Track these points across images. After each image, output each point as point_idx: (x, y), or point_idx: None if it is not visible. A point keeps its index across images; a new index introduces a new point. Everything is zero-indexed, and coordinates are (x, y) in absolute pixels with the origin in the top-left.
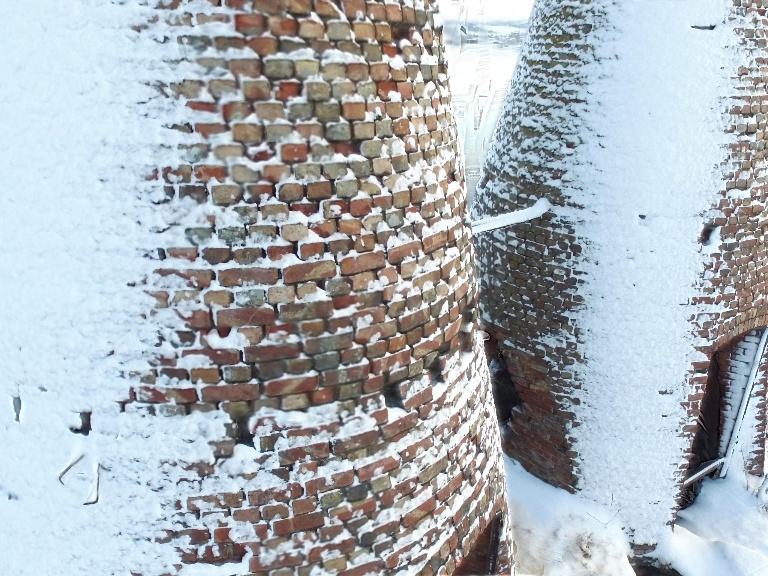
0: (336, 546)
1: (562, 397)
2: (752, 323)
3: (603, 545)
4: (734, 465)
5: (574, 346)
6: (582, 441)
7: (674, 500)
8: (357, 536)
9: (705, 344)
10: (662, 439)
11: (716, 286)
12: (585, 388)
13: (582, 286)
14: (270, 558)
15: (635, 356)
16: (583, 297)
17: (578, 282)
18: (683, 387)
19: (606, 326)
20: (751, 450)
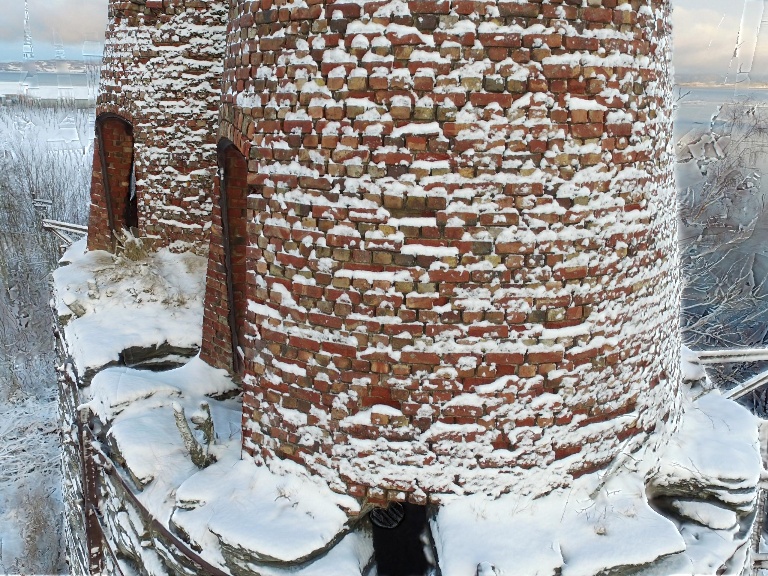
0: None
1: None
2: None
3: None
4: None
5: None
6: None
7: None
8: None
9: None
10: None
11: None
12: None
13: None
14: None
15: None
16: None
17: None
18: None
19: None
20: None
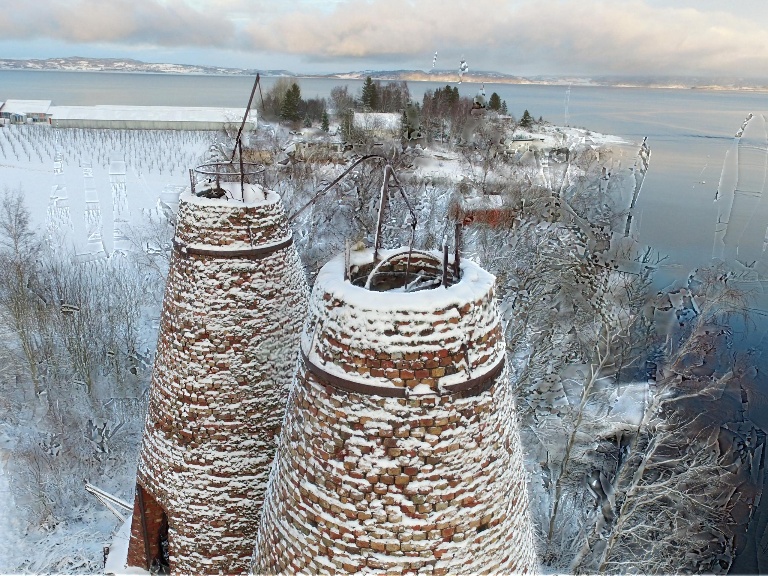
0: None
1: None
2: None
3: None
4: None
5: None
6: None
7: None
8: None
9: None
10: None
11: None
12: None
13: None
14: None
15: None
16: None
17: None
18: None
19: None
20: None
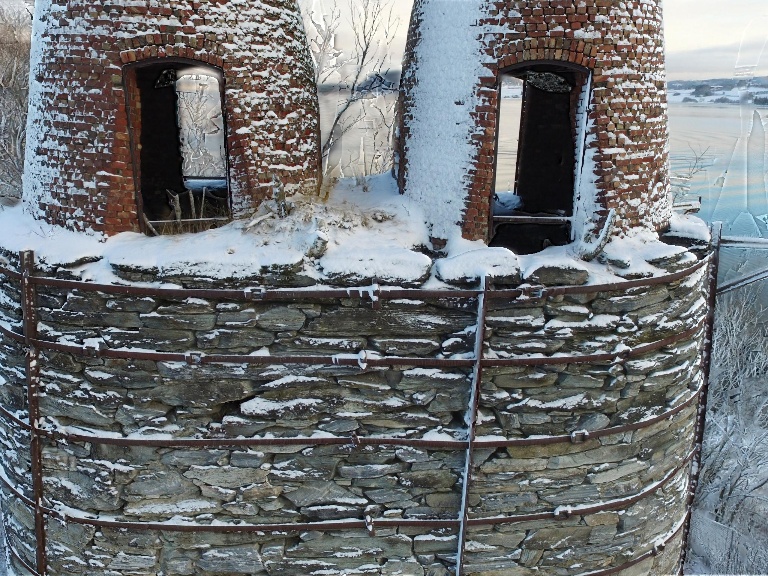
0: (95, 6)
1: (406, 116)
2: (551, 53)
3: (398, 222)
4: (579, 225)
5: (414, 73)
6: (411, 149)
7: (463, 202)
8: (104, 5)
9: (491, 61)
10: (455, 144)
11: (501, 10)
12: (416, 105)
13: (421, 24)
14: (73, 5)
15: (441, 72)
16: (421, 32)
17: (420, 22)
18: (472, 98)
19: (428, 51)
20: (594, 210)
